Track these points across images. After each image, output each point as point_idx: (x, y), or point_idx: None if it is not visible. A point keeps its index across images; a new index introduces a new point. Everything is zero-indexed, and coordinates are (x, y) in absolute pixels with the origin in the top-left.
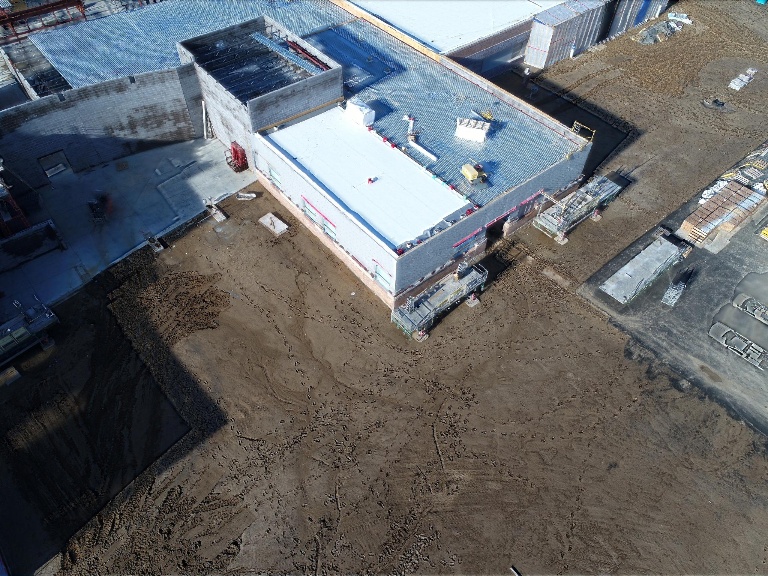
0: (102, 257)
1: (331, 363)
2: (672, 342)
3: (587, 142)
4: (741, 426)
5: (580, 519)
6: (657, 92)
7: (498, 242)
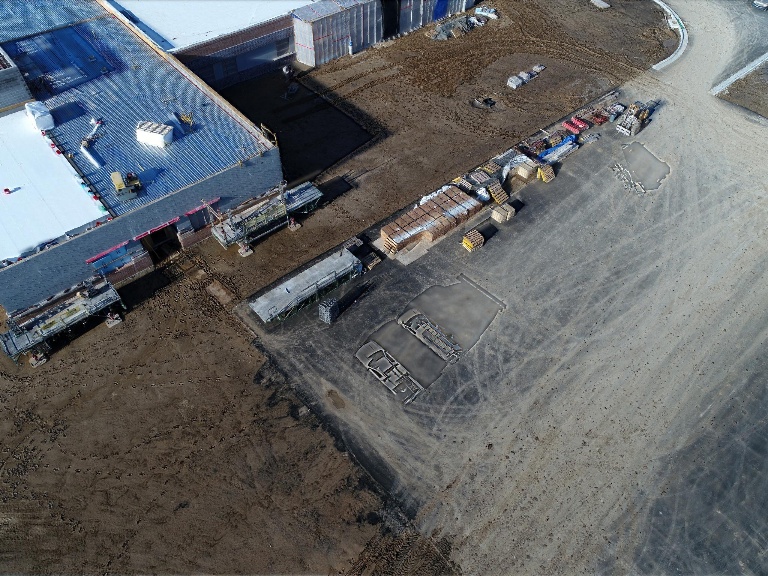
0: None
1: None
2: (310, 364)
3: (273, 146)
4: (343, 458)
5: (116, 568)
6: (427, 91)
7: (174, 255)
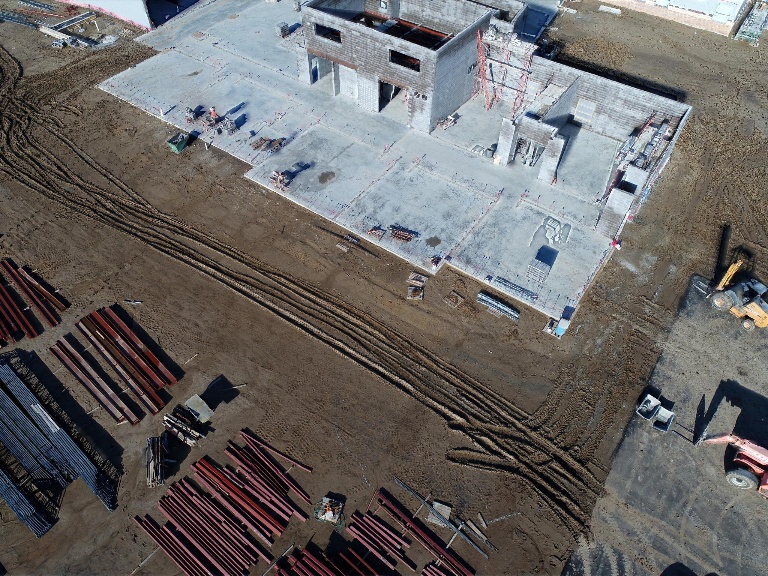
0: (526, 37)
1: (718, 62)
2: None
3: None
4: None
5: None
6: None
7: (750, 1)
